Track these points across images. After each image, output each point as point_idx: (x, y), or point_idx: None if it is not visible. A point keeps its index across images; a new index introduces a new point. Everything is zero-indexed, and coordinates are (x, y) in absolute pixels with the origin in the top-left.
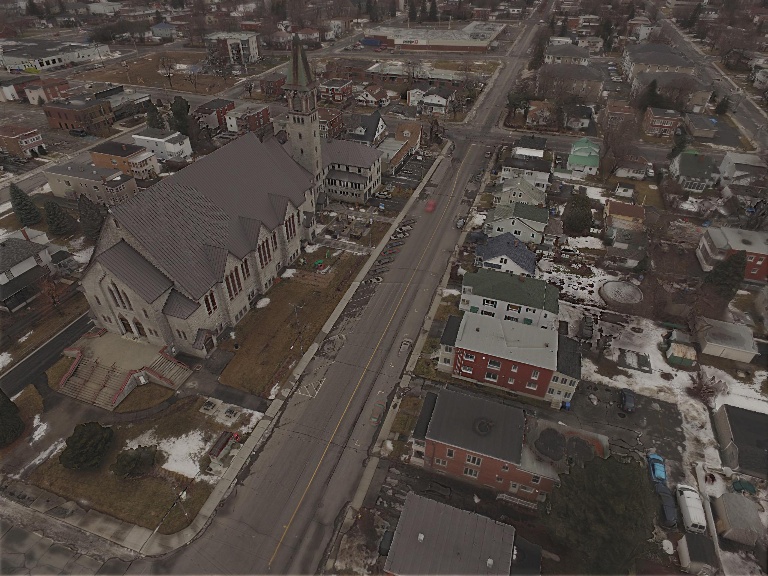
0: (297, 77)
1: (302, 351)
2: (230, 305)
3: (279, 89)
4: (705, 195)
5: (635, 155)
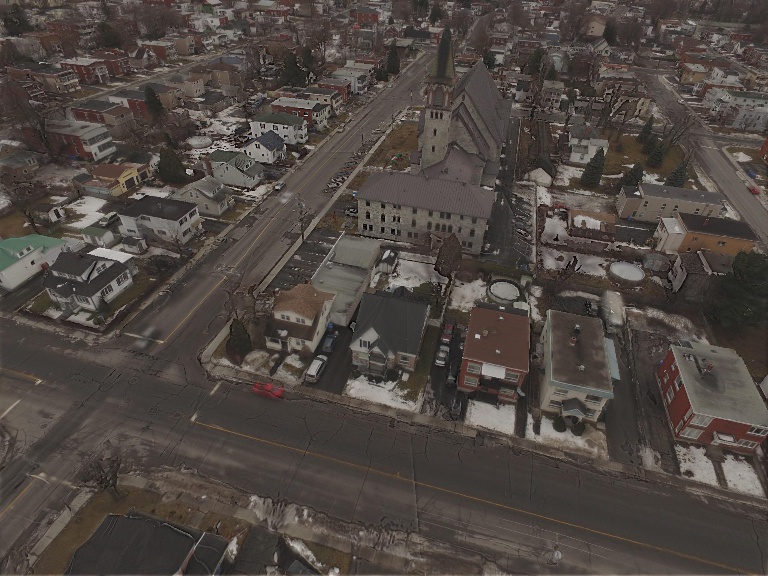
0: None
1: None
2: None
3: None
4: None
5: None
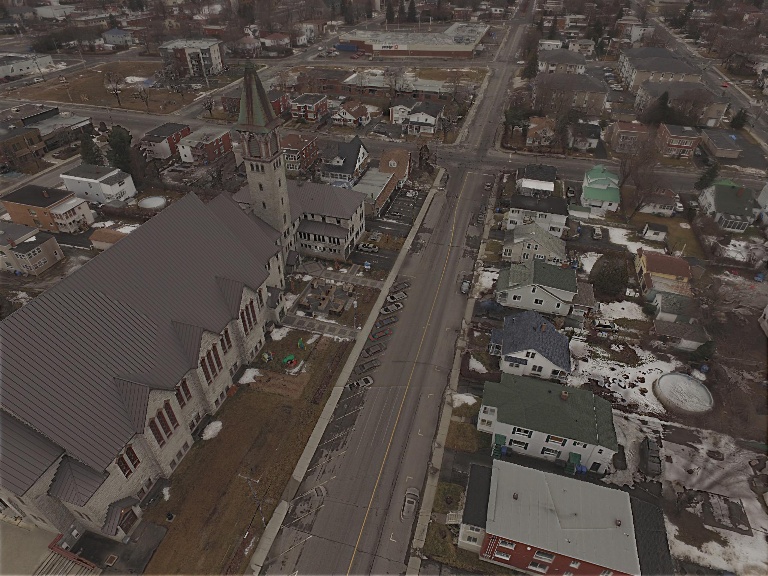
0: (252, 115)
1: (264, 522)
2: (160, 453)
3: None
4: (747, 235)
5: (662, 187)
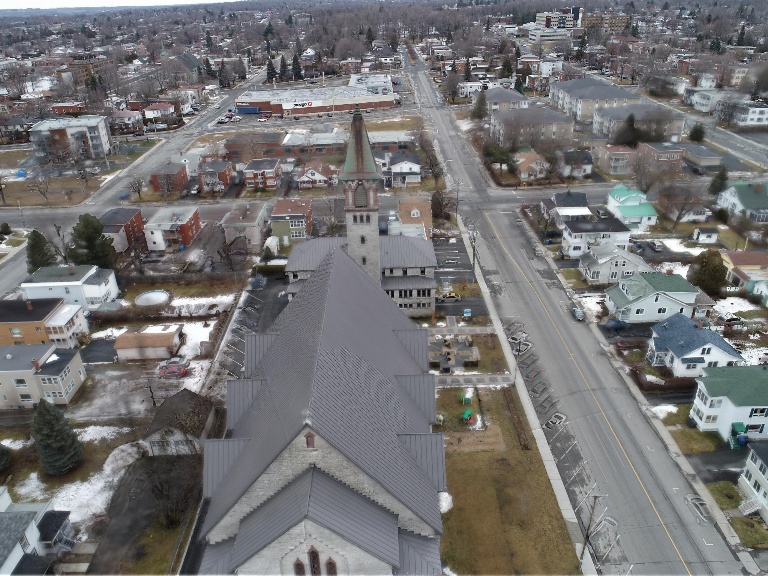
0: (362, 162)
1: (581, 564)
2: None
3: (180, 183)
4: None
5: None
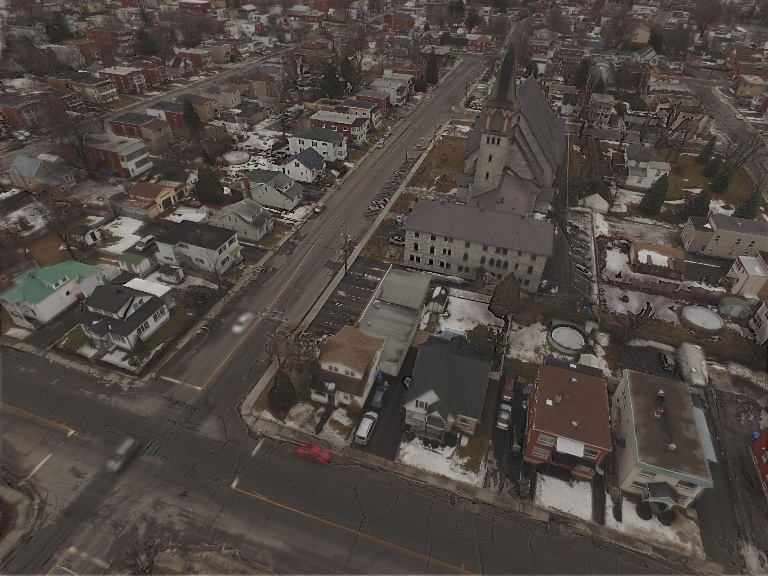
0: None
1: None
2: None
3: None
4: None
5: None
